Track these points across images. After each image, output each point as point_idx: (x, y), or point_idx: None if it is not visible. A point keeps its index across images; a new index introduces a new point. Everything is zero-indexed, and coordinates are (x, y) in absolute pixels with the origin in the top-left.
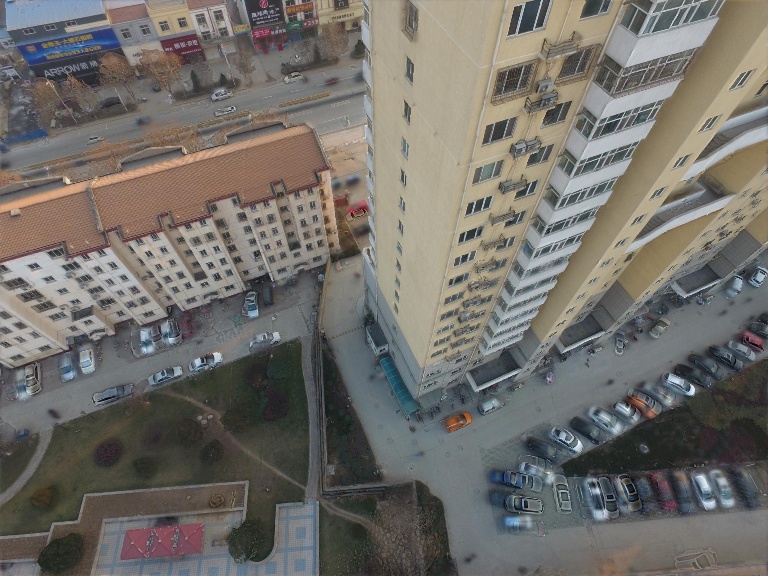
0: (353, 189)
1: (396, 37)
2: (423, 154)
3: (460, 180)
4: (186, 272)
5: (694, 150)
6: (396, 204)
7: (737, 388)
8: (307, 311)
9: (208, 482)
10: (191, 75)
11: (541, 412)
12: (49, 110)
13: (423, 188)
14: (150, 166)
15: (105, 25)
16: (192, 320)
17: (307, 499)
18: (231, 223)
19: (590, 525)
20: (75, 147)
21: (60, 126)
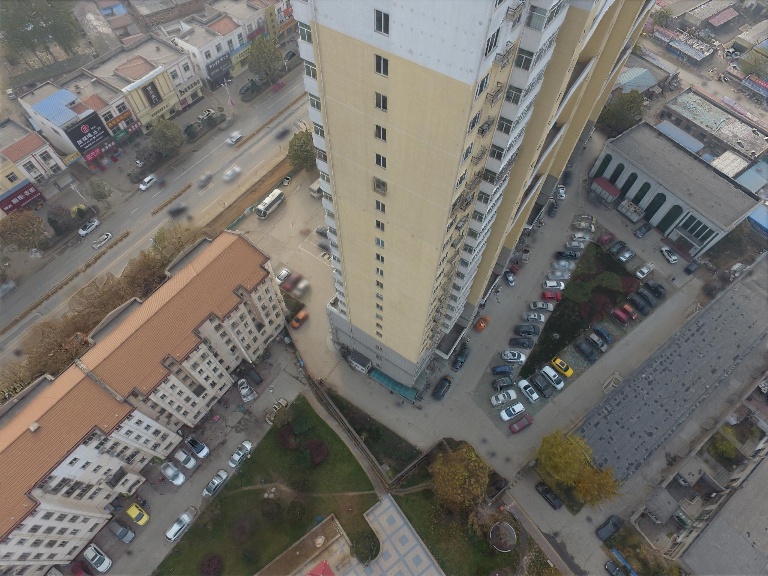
0: None
1: (364, 191)
2: (401, 245)
3: (438, 255)
4: (191, 394)
5: (528, 178)
6: (373, 273)
7: (584, 270)
8: (293, 371)
9: (304, 534)
10: (49, 223)
11: (489, 348)
12: None
13: (403, 262)
14: (119, 327)
15: None
16: (205, 430)
17: (381, 497)
18: (211, 337)
19: (553, 399)
20: None
21: None
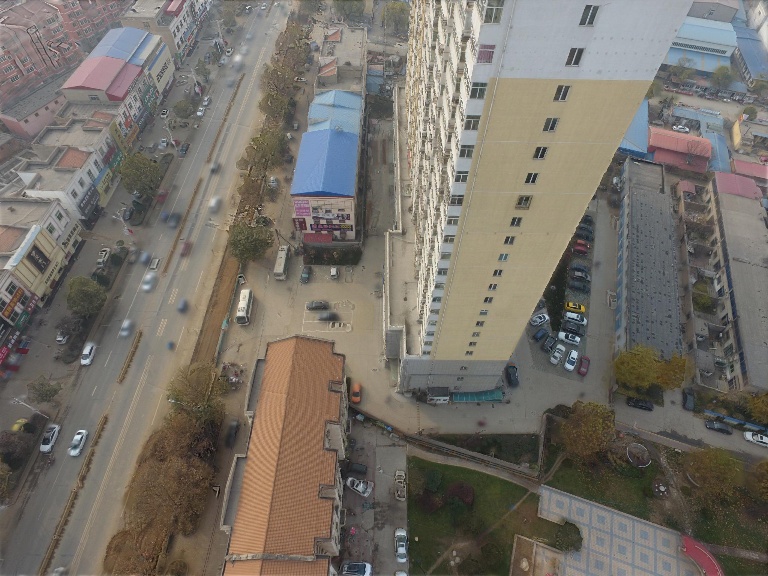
0: None
1: (501, 215)
2: None
3: None
4: (336, 518)
5: None
6: (485, 291)
7: None
8: (385, 441)
9: (508, 569)
10: None
11: None
12: None
13: (527, 263)
14: (244, 495)
15: None
16: (349, 550)
17: (538, 492)
18: None
19: (587, 335)
20: None
21: None
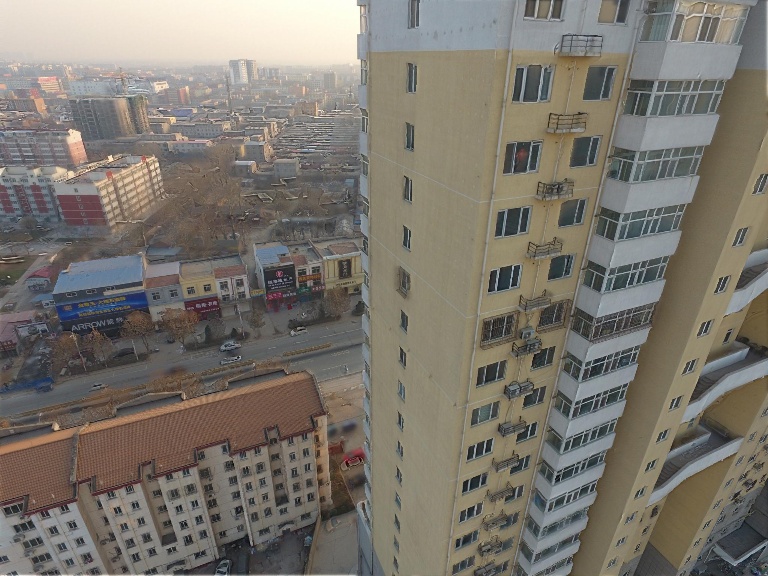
0: (349, 436)
1: (392, 295)
2: (419, 396)
3: (458, 421)
4: (154, 534)
5: (684, 392)
6: (393, 449)
7: None
8: None
9: None
10: (205, 329)
11: None
12: (64, 359)
13: (421, 431)
14: (146, 411)
15: (140, 290)
16: None
17: None
18: (216, 473)
19: None
20: (76, 394)
21: (69, 374)
